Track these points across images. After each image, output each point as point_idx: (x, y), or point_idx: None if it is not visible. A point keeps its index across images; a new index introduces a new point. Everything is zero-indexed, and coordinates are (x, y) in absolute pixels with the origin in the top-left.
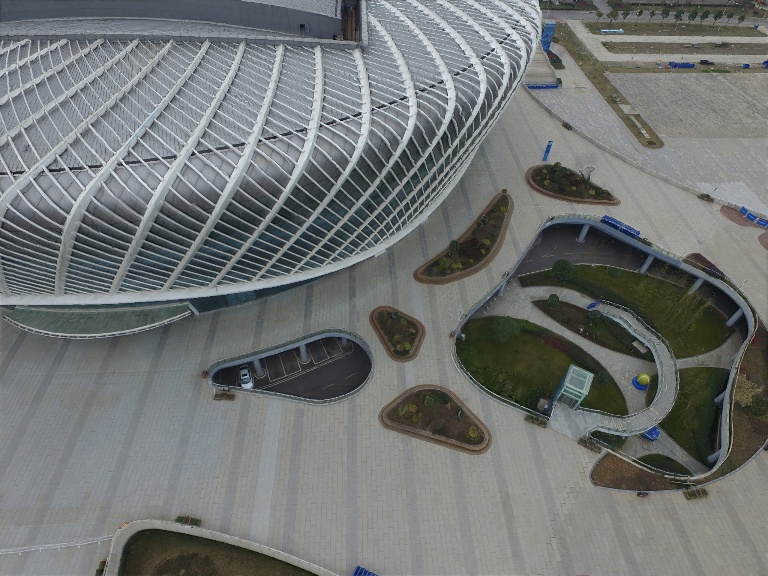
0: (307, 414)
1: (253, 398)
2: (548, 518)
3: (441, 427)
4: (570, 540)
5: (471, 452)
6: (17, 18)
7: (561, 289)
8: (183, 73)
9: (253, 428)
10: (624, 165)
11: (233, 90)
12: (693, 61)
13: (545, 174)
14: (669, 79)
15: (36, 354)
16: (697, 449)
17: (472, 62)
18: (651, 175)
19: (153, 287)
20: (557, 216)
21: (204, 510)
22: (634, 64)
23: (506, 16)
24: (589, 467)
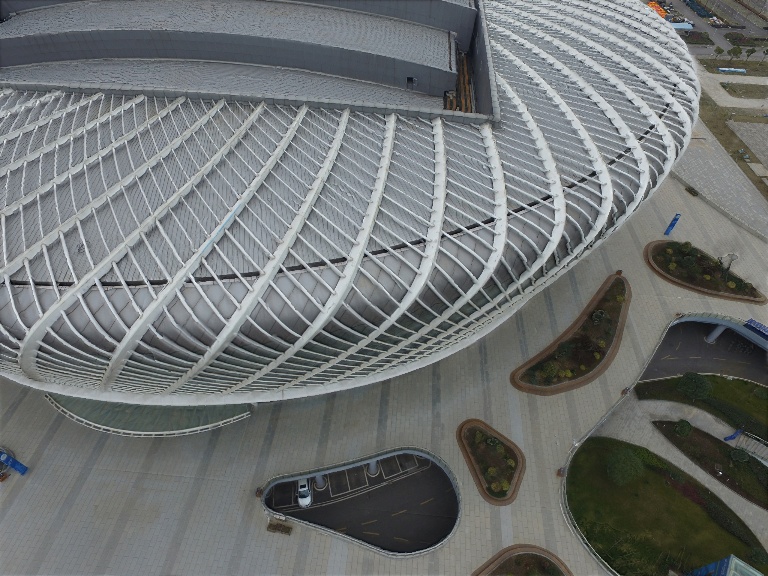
0: (378, 569)
1: (313, 534)
2: None
3: None
4: None
5: None
6: (96, 56)
7: (689, 408)
8: (274, 149)
9: None
10: (767, 249)
11: (334, 178)
12: None
13: (670, 255)
14: None
15: (76, 437)
16: None
17: (629, 145)
18: None
19: None
20: (688, 314)
21: None
22: (762, 112)
23: (661, 78)
24: None
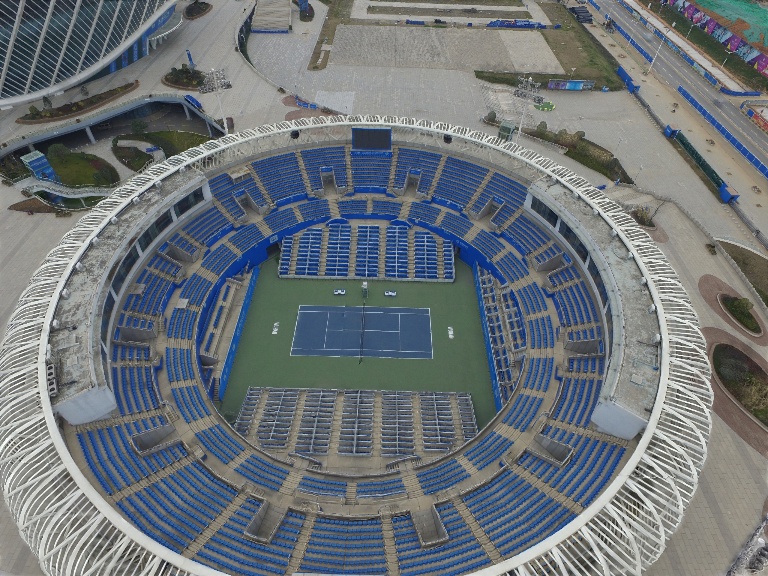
0: None
1: None
2: None
3: None
4: None
5: None
6: None
7: (141, 142)
8: None
9: None
10: (249, 72)
11: None
12: (431, 20)
13: None
14: (387, 30)
15: None
16: None
17: None
18: (261, 78)
19: None
20: (154, 94)
21: None
22: (377, 21)
23: None
24: (15, 202)
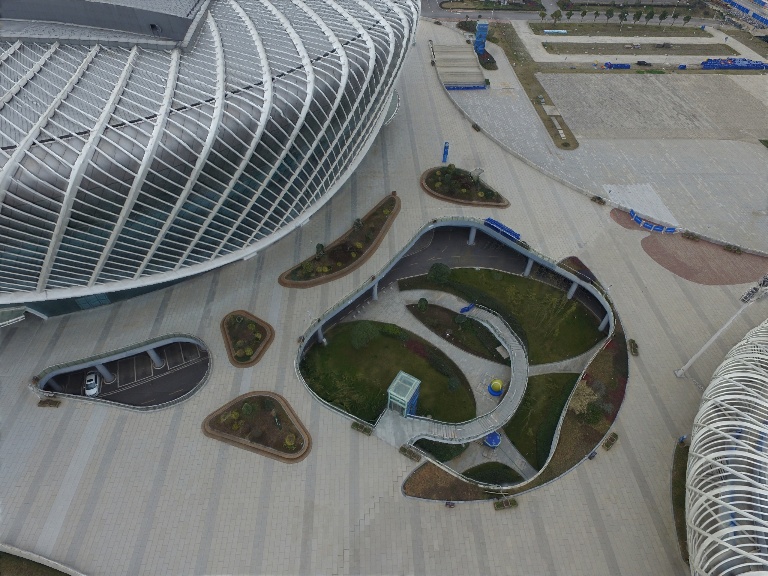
0: (129, 421)
1: (79, 405)
2: (347, 529)
3: (259, 435)
4: (364, 552)
5: (287, 461)
6: None
7: (439, 293)
8: None
9: (70, 435)
10: (524, 167)
11: (23, 91)
12: (631, 62)
13: (438, 176)
14: (600, 80)
15: None
16: (536, 457)
17: (303, 63)
18: (549, 177)
19: None
20: (440, 219)
21: None
22: (570, 65)
23: (365, 16)
24: (404, 476)
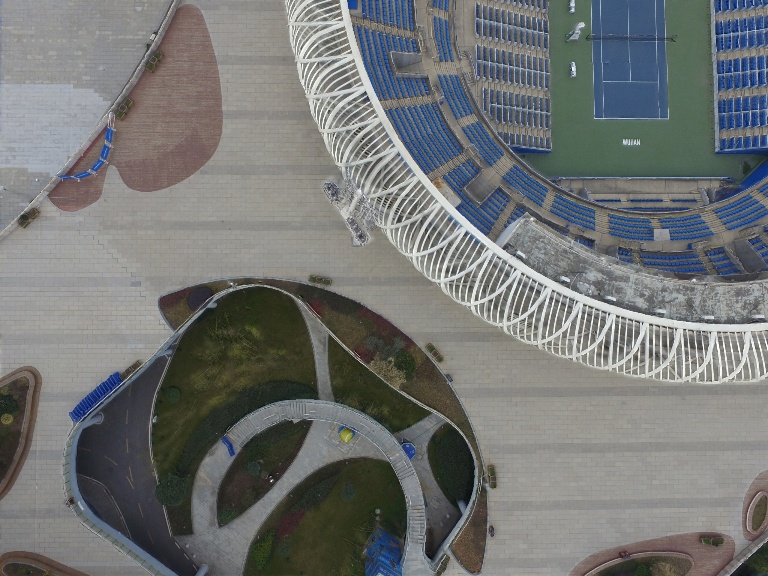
0: None
1: None
2: None
3: None
4: None
5: None
6: None
7: (198, 480)
8: None
9: None
10: None
11: None
12: None
13: None
14: None
15: None
16: None
17: None
18: None
19: None
20: (67, 495)
21: None
22: None
23: None
24: (463, 572)
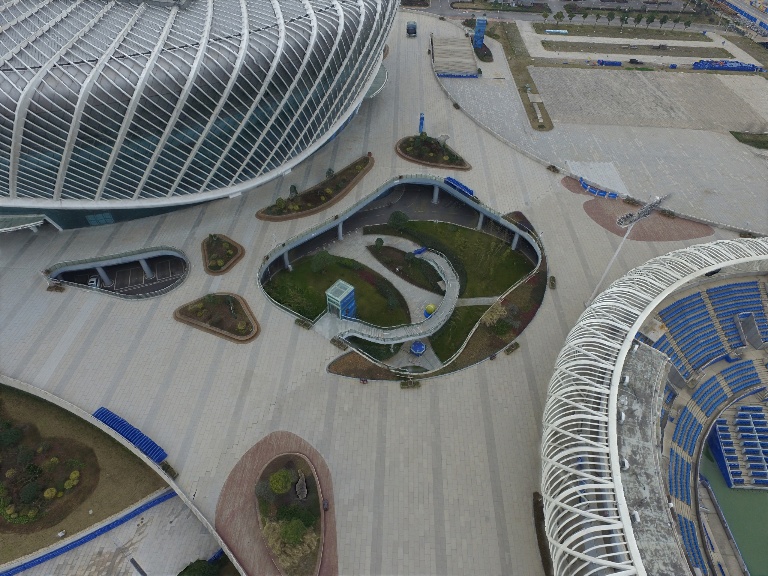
0: (117, 306)
1: (79, 292)
2: (276, 391)
3: (217, 320)
4: (286, 407)
5: (237, 341)
6: None
7: (397, 238)
8: None
9: (69, 312)
10: (492, 139)
11: (51, 30)
12: (624, 60)
13: (411, 142)
14: (588, 74)
15: None
16: None
17: (278, 22)
18: (513, 149)
19: (2, 193)
20: (405, 175)
21: (5, 363)
22: (563, 61)
23: None
24: (331, 359)
